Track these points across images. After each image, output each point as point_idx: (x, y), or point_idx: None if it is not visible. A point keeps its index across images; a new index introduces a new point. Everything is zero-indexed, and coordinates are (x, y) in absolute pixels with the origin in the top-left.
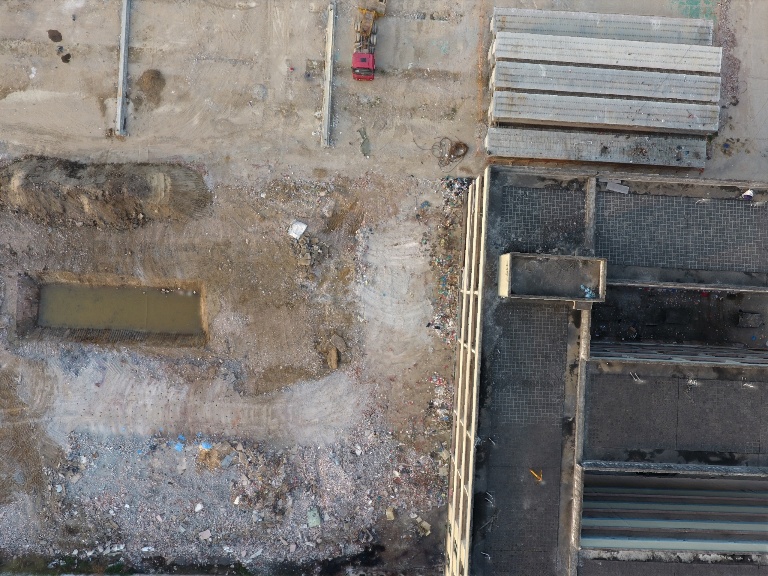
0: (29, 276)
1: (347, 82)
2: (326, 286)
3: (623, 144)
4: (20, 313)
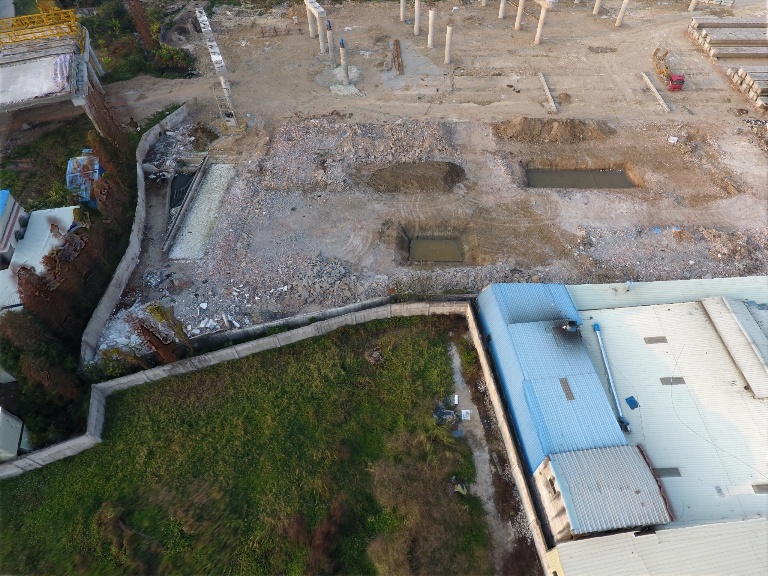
0: (522, 163)
1: (665, 93)
2: (705, 160)
3: None
4: (522, 177)
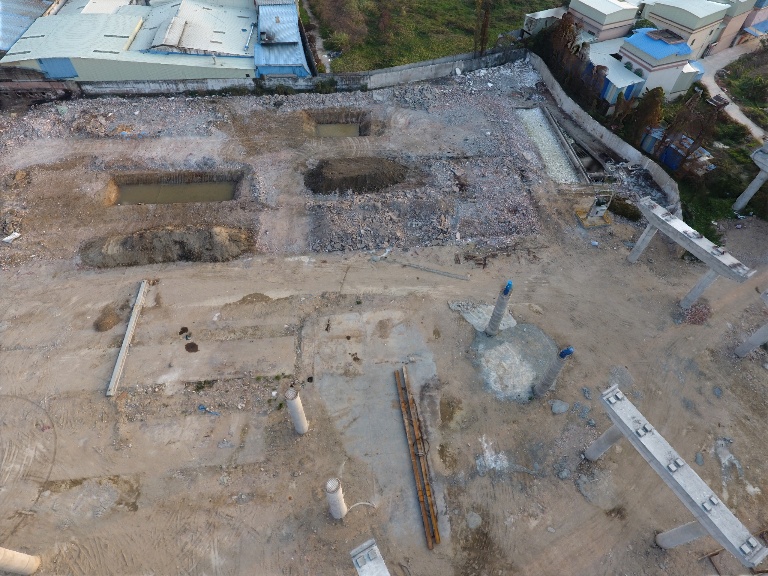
0: None
1: None
2: (5, 209)
3: None
4: None
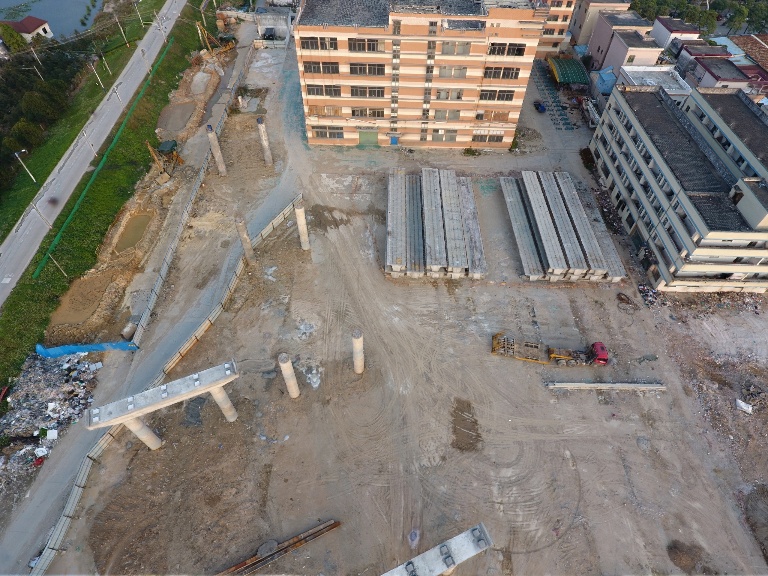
0: None
1: (606, 372)
2: None
3: (588, 212)
4: None
